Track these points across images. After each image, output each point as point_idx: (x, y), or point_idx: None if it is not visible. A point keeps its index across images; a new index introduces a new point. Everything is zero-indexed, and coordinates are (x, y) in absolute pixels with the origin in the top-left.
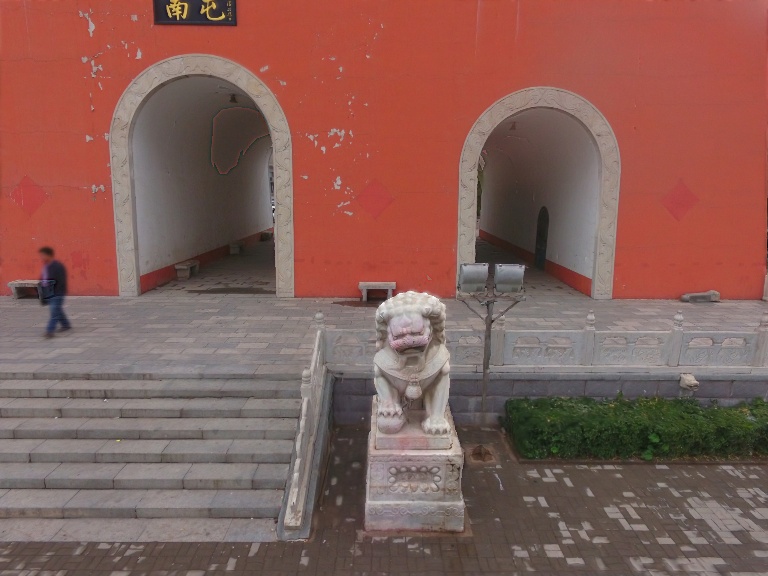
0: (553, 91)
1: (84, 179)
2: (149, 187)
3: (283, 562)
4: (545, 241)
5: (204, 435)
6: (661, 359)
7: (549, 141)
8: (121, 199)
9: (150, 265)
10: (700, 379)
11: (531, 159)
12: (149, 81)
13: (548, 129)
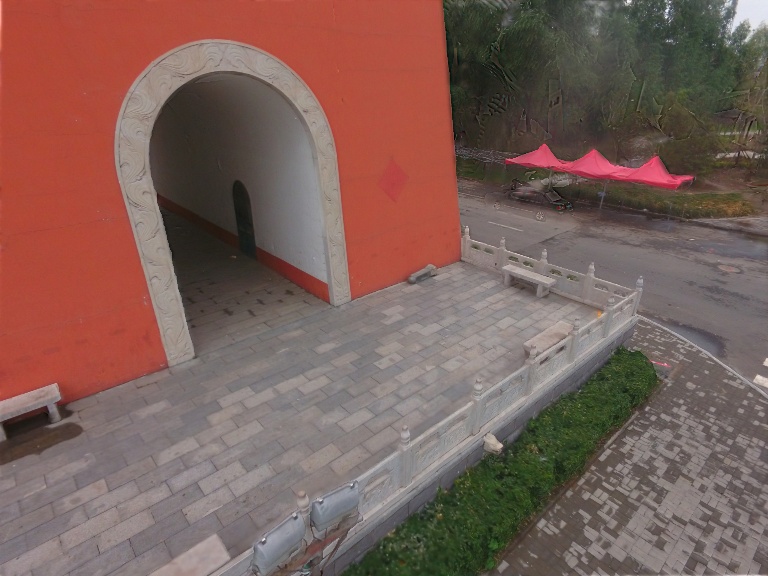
0: (237, 47)
1: None
2: None
3: None
4: (250, 225)
5: None
6: (466, 432)
7: (231, 100)
8: None
9: None
10: (496, 432)
11: (204, 115)
12: None
13: (230, 89)
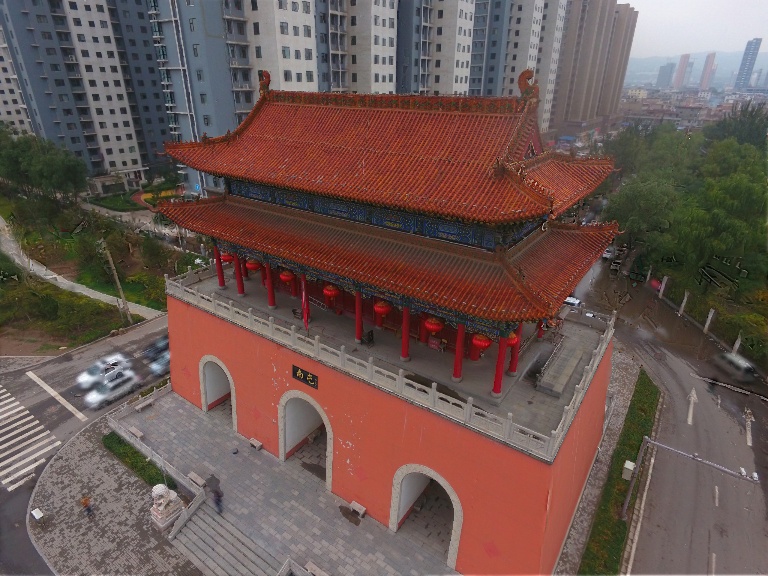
0: (434, 472)
1: (271, 416)
2: (294, 417)
3: None
4: None
5: (255, 574)
6: None
7: None
8: (281, 428)
9: (292, 446)
10: None
11: None
12: (290, 395)
13: None
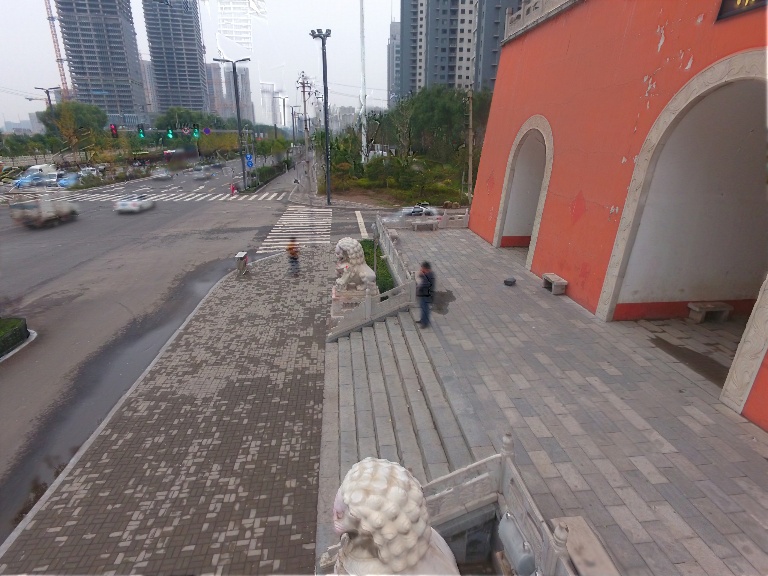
0: None
1: (609, 199)
2: (672, 212)
3: (294, 569)
4: None
5: None
6: None
7: None
8: (625, 224)
9: (640, 295)
10: None
11: None
12: (688, 94)
13: None
